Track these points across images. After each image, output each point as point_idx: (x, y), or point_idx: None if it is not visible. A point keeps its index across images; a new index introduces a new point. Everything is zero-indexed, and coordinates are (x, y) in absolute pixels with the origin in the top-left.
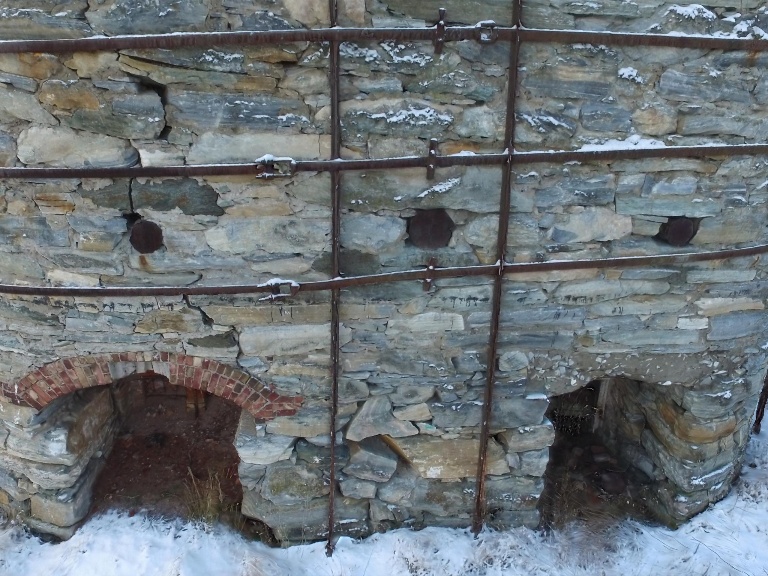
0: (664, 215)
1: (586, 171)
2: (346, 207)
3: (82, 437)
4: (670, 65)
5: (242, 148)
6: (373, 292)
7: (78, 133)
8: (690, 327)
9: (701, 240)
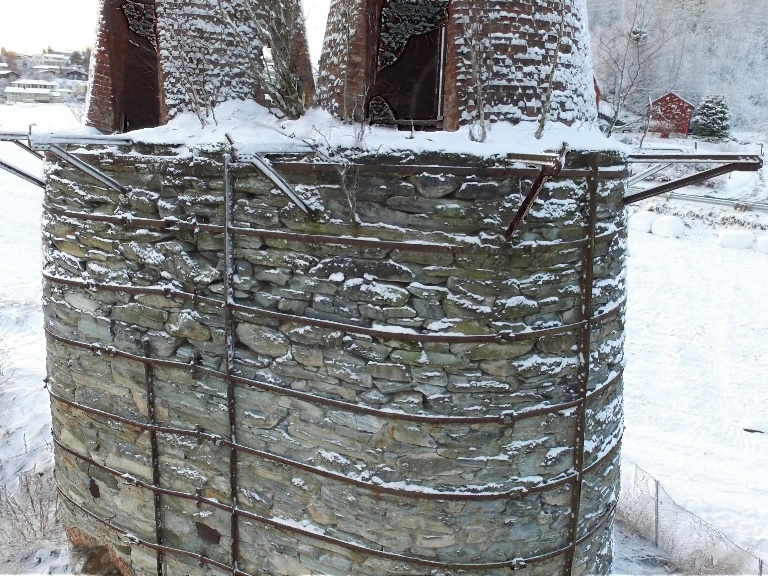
0: None
1: (278, 532)
2: None
3: (99, 563)
4: (324, 484)
5: (123, 465)
6: (179, 556)
7: (75, 437)
8: None
9: None
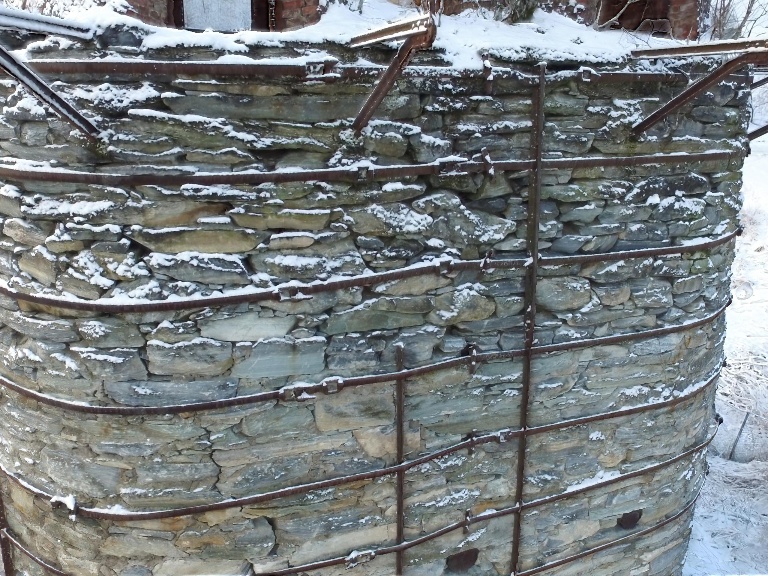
0: (620, 514)
1: (570, 502)
2: (406, 565)
3: None
4: (622, 424)
5: (332, 546)
6: None
7: (205, 560)
8: (638, 573)
9: (644, 521)
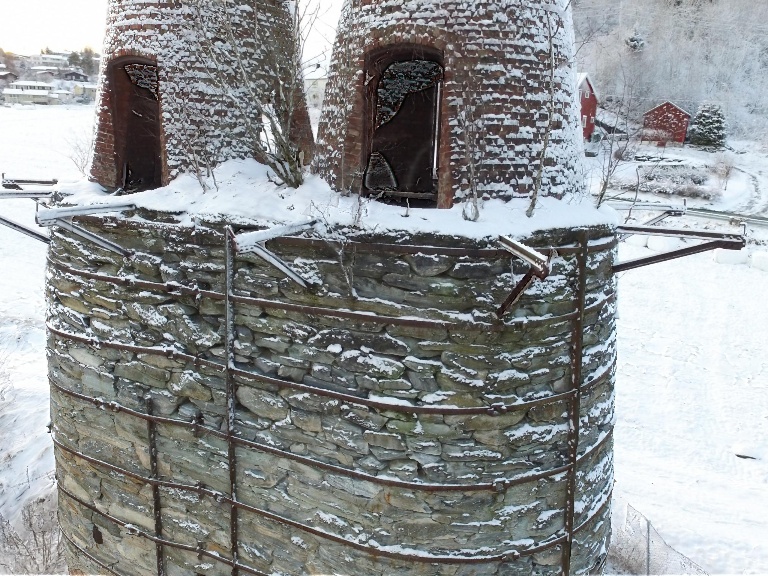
0: None
1: None
2: None
3: None
4: (322, 544)
5: (126, 514)
6: None
7: (78, 484)
8: None
9: None
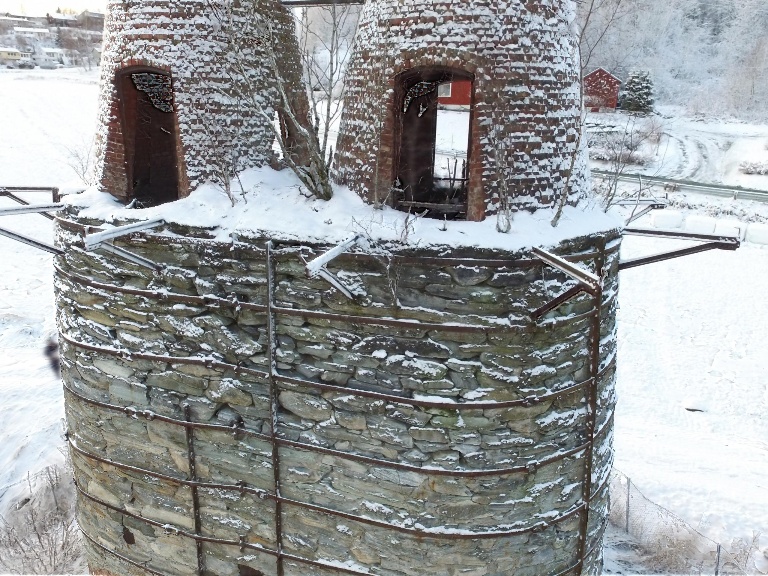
0: None
1: None
2: (206, 553)
3: None
4: (368, 530)
5: (161, 515)
6: None
7: None
8: None
9: None
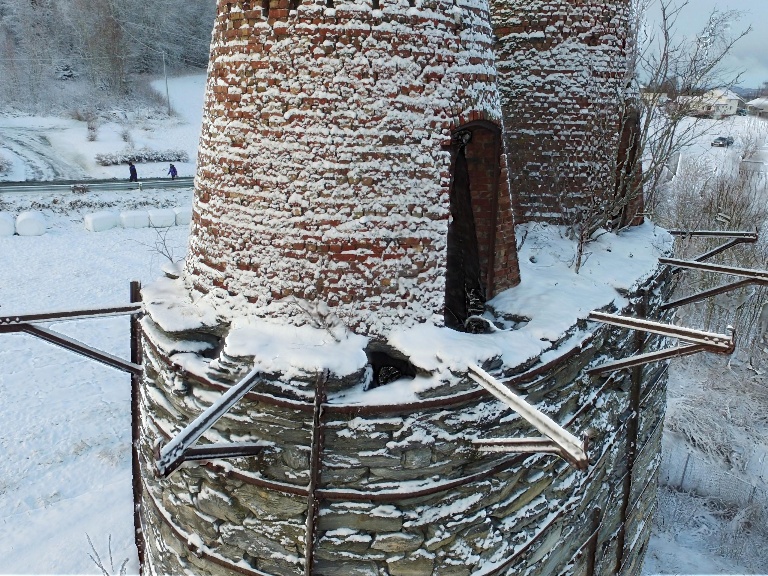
0: None
1: None
2: None
3: None
4: None
5: None
6: None
7: None
8: None
9: None
